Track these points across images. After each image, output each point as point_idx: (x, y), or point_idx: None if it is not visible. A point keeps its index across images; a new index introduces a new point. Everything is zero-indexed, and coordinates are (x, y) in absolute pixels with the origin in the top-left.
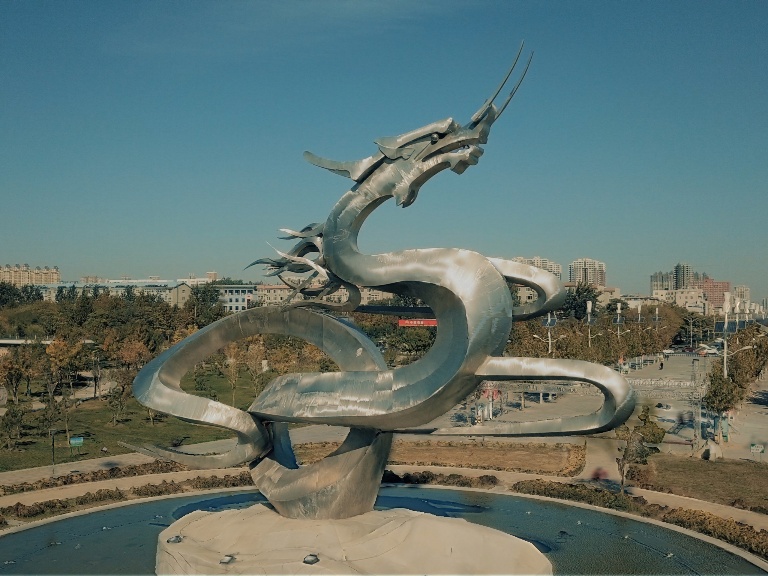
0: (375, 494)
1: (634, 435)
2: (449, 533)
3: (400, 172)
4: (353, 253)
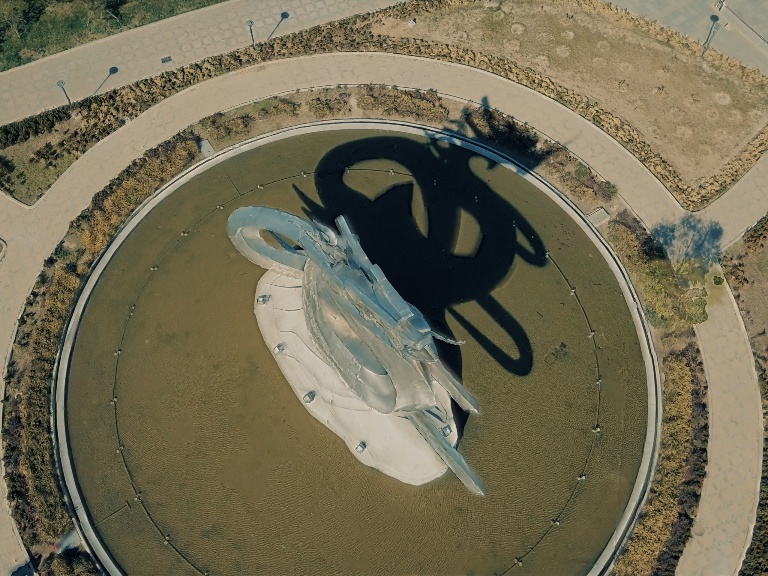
0: None
1: (694, 291)
2: (388, 428)
3: (362, 311)
4: (339, 304)
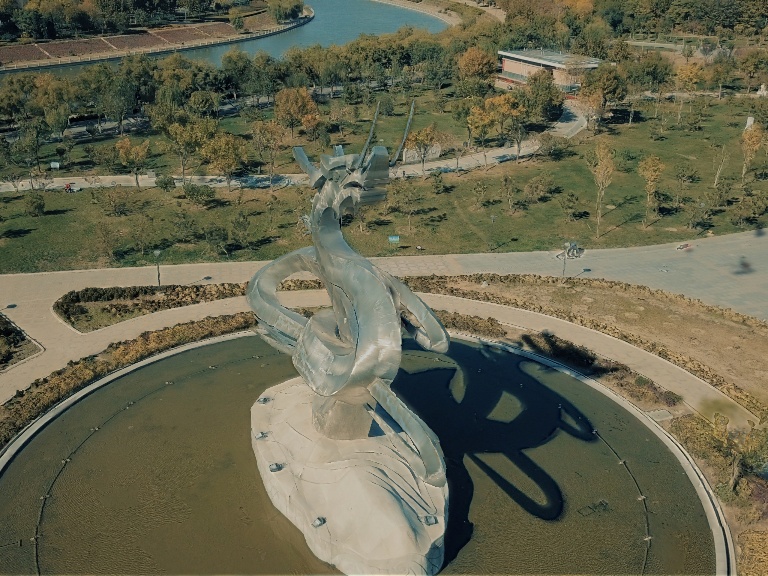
0: (366, 428)
1: None
2: (357, 493)
3: (334, 192)
4: (321, 246)
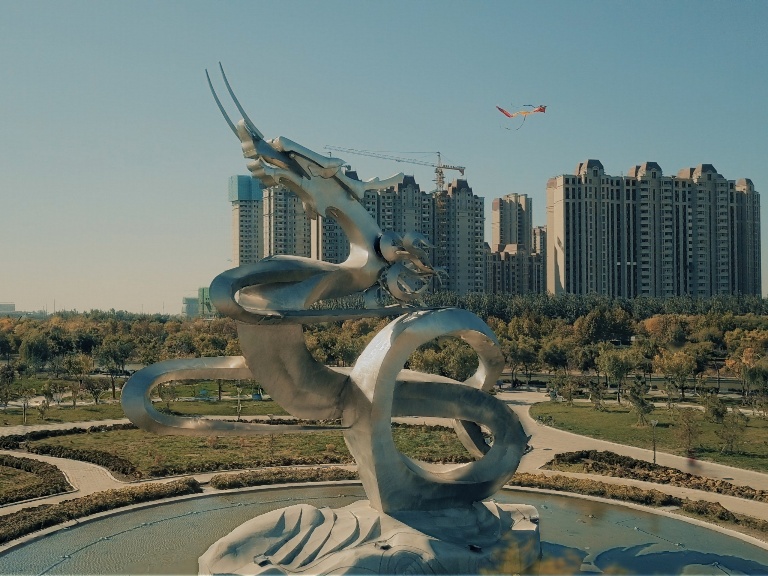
0: None
1: None
2: None
3: None
4: None
